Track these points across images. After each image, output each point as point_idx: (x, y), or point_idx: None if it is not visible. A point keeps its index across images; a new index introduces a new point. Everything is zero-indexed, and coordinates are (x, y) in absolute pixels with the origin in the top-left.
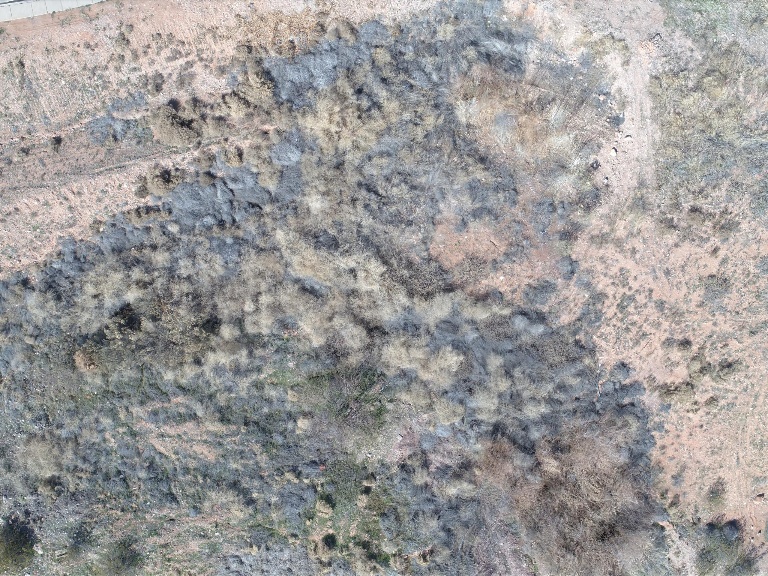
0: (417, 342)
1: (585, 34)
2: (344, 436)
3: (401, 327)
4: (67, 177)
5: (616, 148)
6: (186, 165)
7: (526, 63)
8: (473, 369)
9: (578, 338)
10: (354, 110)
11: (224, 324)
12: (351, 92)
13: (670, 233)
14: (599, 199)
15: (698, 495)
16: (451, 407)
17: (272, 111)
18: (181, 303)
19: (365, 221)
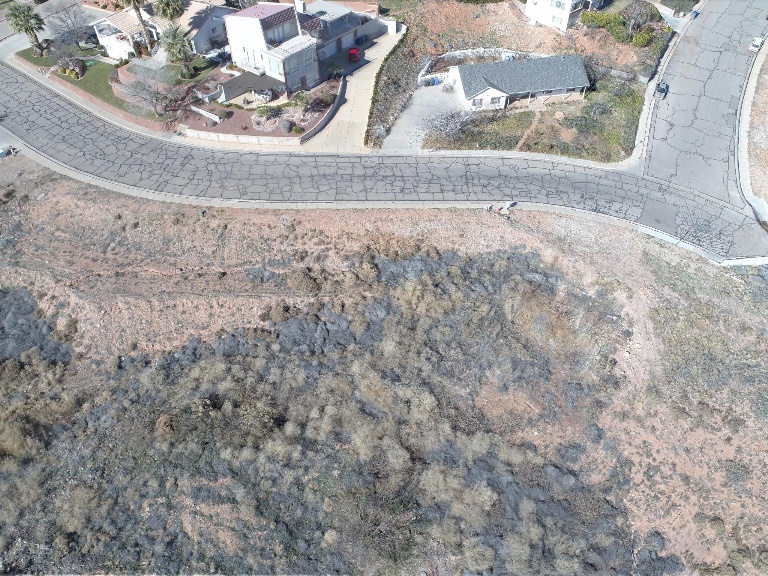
0: (455, 471)
1: (598, 277)
2: (367, 560)
3: (442, 459)
4: (219, 293)
5: (629, 352)
6: (302, 306)
7: (557, 291)
8: (506, 513)
9: (609, 499)
10: (431, 293)
11: (290, 422)
12: (431, 282)
13: (684, 417)
14: (619, 385)
15: None
16: (481, 549)
17: (373, 283)
18: (260, 400)
19: (425, 367)
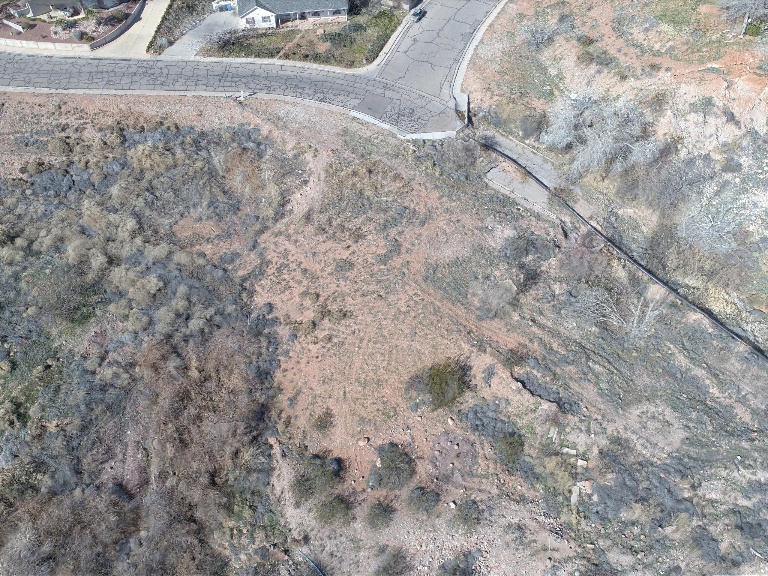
0: (135, 268)
1: (296, 143)
2: (54, 324)
3: None
4: None
5: (302, 194)
6: (56, 163)
7: (265, 155)
8: (167, 295)
9: (245, 285)
10: (159, 153)
11: None
12: (162, 147)
13: (320, 233)
14: (285, 216)
15: (308, 421)
16: (140, 316)
17: (115, 147)
18: (4, 224)
19: (139, 204)
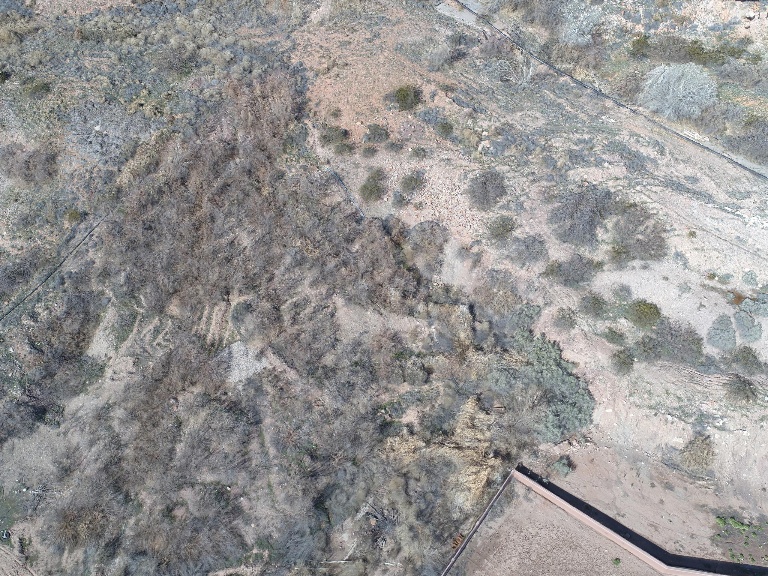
0: None
1: None
2: (169, 76)
3: None
4: None
5: None
6: None
7: None
8: (236, 61)
9: None
10: None
11: None
12: None
13: (330, 29)
14: (306, 23)
15: (327, 113)
16: (221, 71)
17: None
18: None
19: None
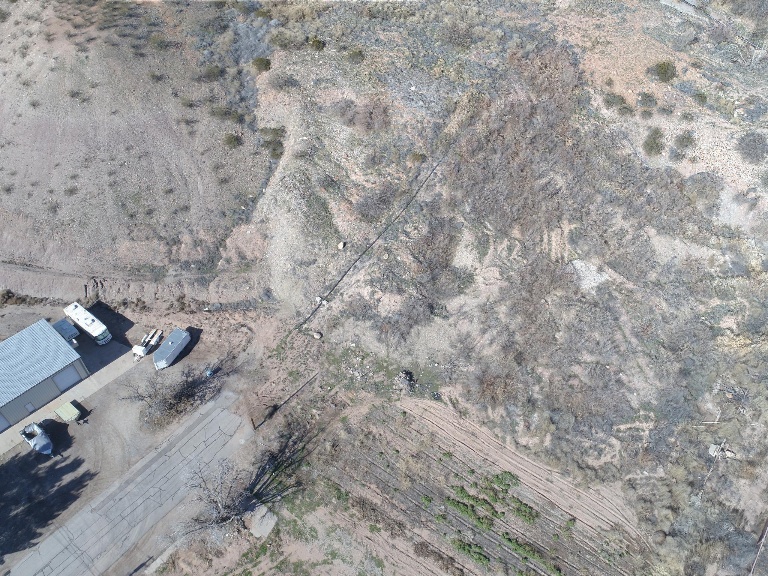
0: None
1: None
2: (453, 49)
3: None
4: None
5: (561, 0)
6: None
7: None
8: None
9: None
10: None
11: None
12: None
13: (581, 14)
14: None
15: (602, 82)
16: (497, 46)
17: None
18: None
19: (473, 3)
